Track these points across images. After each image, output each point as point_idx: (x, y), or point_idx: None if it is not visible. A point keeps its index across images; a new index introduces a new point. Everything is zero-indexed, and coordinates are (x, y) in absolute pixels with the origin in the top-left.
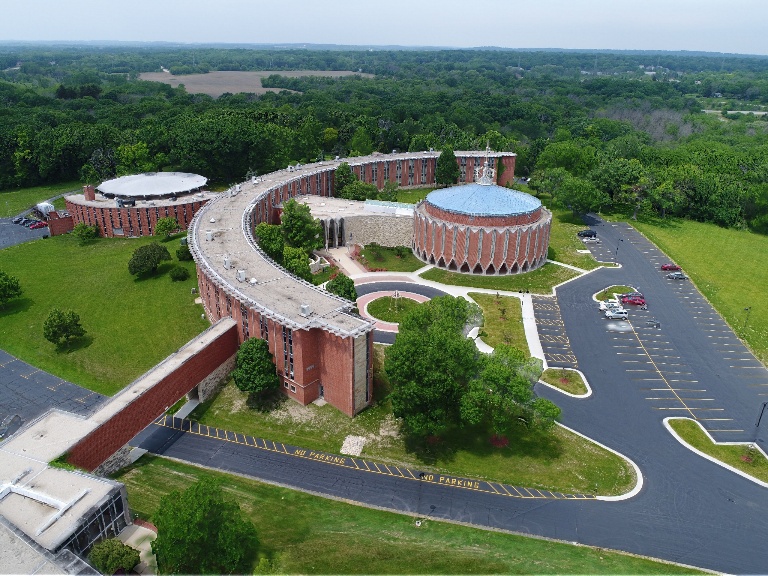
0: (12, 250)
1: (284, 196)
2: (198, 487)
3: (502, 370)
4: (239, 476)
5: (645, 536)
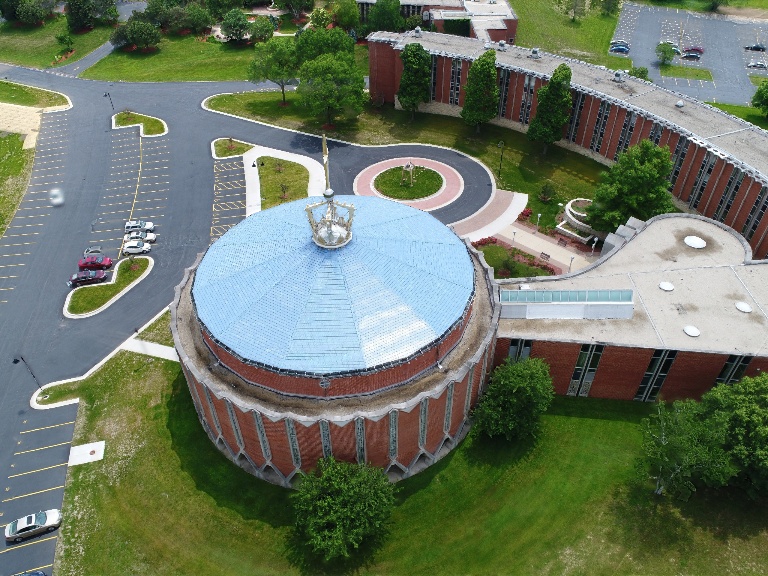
0: None
1: None
2: None
3: None
4: None
5: None
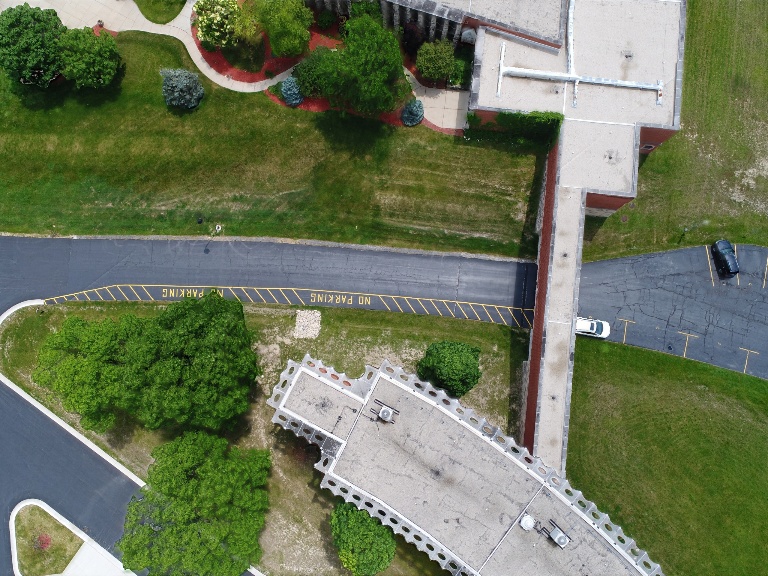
0: None
1: None
2: (367, 57)
3: (86, 336)
4: (415, 249)
5: (8, 259)
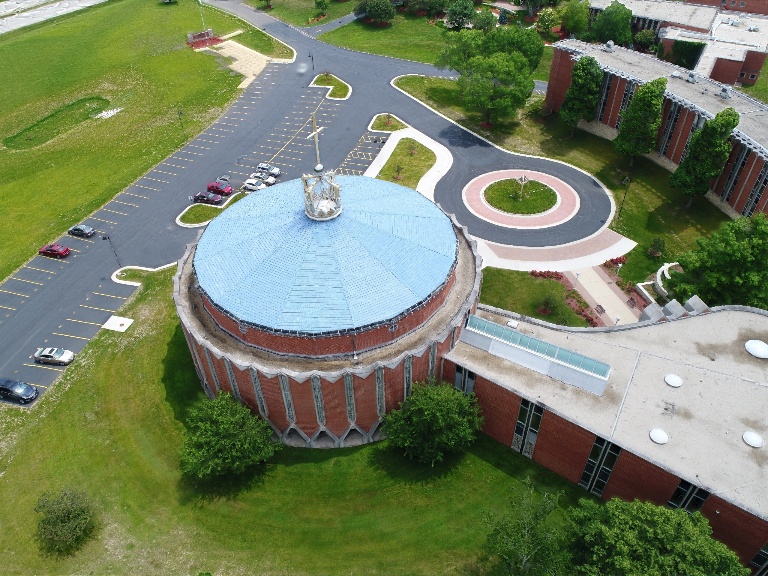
0: None
1: None
2: None
3: None
4: None
5: None
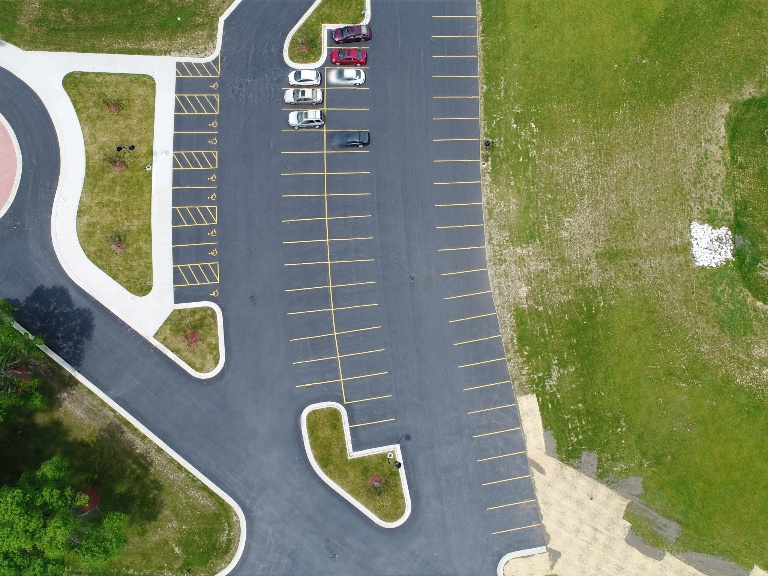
0: None
1: None
2: None
3: (3, 573)
4: None
5: None
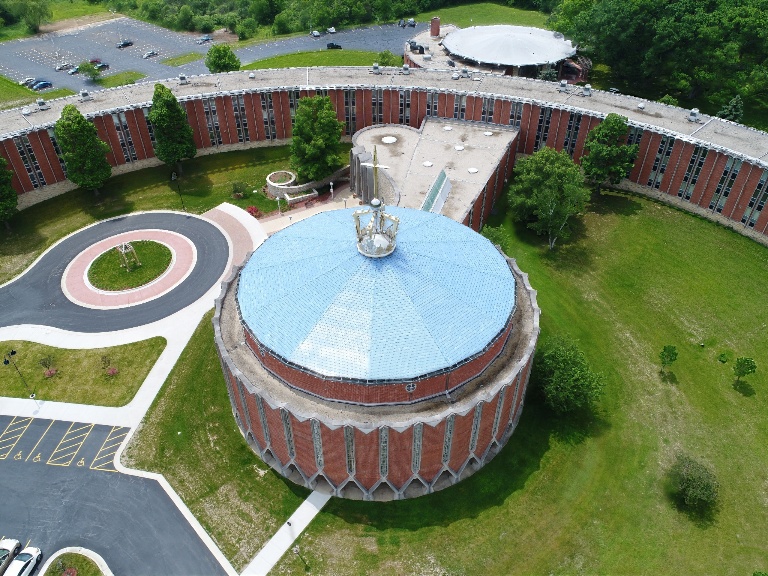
0: (368, 55)
1: (469, 113)
2: None
3: None
4: None
5: None
